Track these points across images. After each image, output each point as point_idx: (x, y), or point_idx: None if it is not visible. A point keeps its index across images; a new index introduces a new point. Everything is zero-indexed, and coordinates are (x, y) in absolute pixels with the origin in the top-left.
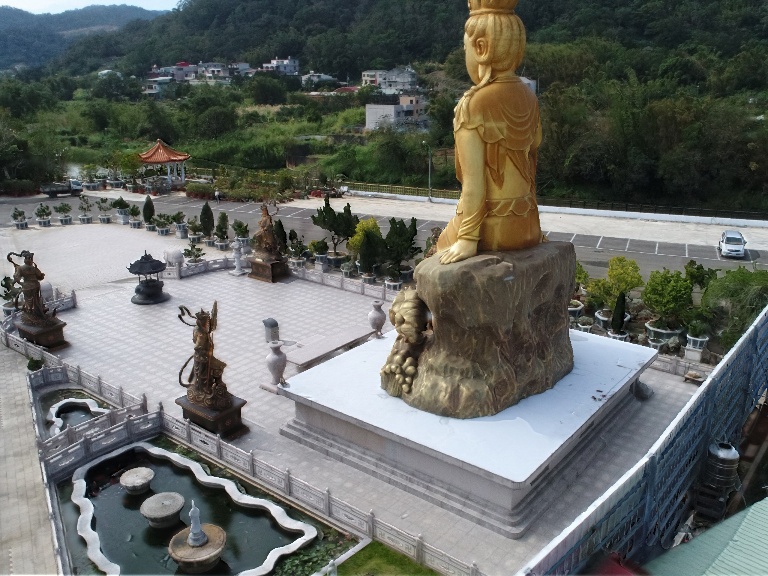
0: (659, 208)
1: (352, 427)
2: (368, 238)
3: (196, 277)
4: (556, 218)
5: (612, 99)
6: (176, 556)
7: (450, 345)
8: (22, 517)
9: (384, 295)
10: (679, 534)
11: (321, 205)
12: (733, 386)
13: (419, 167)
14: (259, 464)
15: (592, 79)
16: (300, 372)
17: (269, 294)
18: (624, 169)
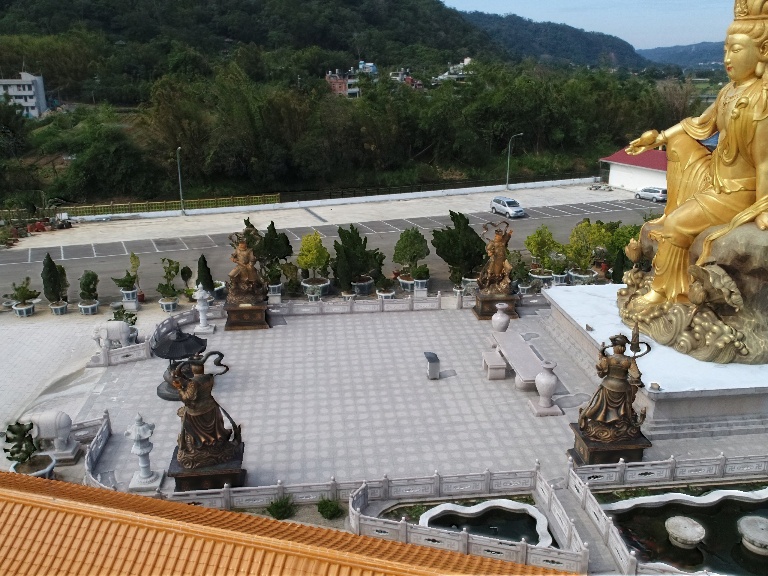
0: (403, 188)
1: (728, 401)
2: (344, 253)
3: None
4: (333, 210)
5: (236, 94)
6: None
7: (763, 303)
8: None
9: (412, 306)
10: None
11: (69, 239)
12: None
13: (26, 183)
14: (734, 461)
15: (206, 74)
16: (530, 390)
17: (300, 339)
18: (262, 161)
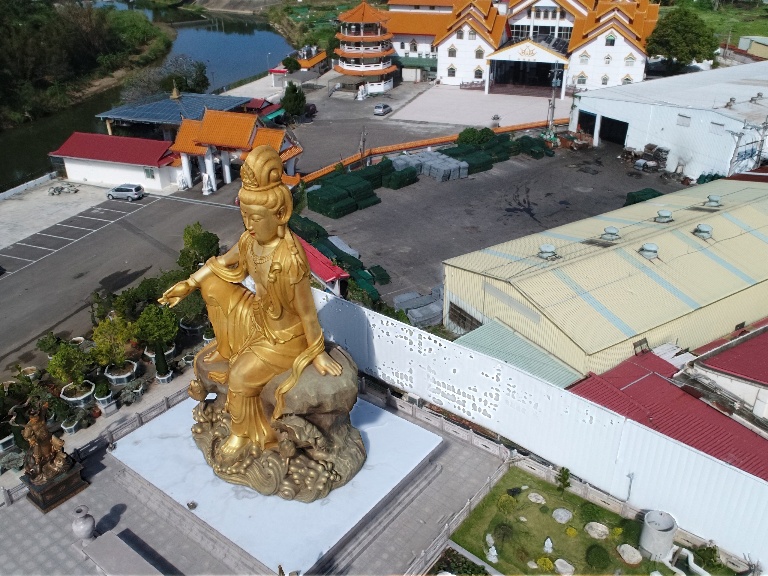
0: None
1: None
2: None
3: None
4: None
5: None
6: None
7: None
8: None
9: None
10: (425, 409)
11: None
12: None
13: None
14: None
15: None
16: None
17: None
18: None
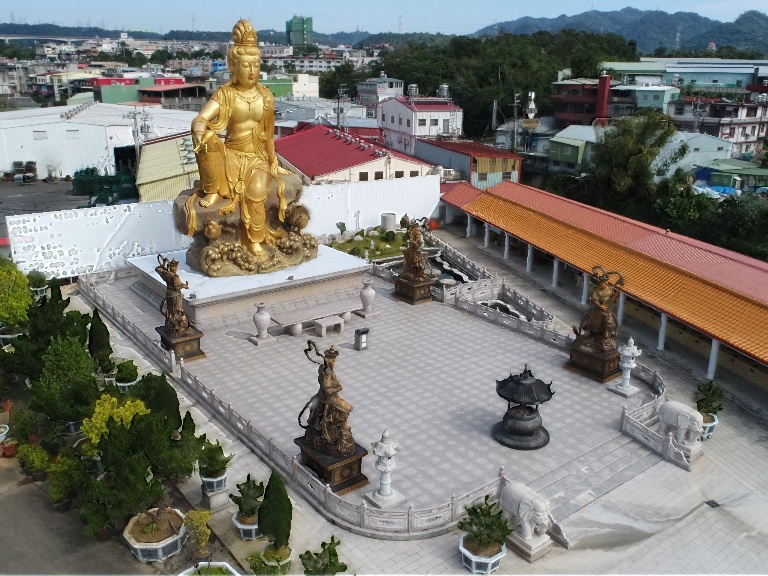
0: None
1: None
2: None
3: None
4: None
5: None
6: None
7: None
8: None
9: None
10: None
11: None
12: (168, 224)
13: None
14: None
15: None
16: None
17: None
18: None
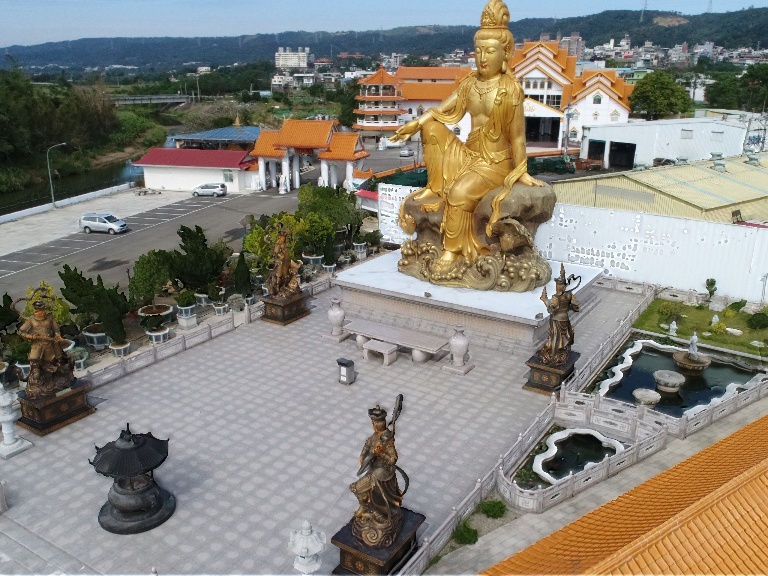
0: None
1: None
2: None
3: (5, 491)
4: None
5: None
6: (710, 361)
7: None
8: (731, 433)
9: None
10: None
11: None
12: None
13: None
14: None
15: None
16: None
17: (158, 406)
18: None
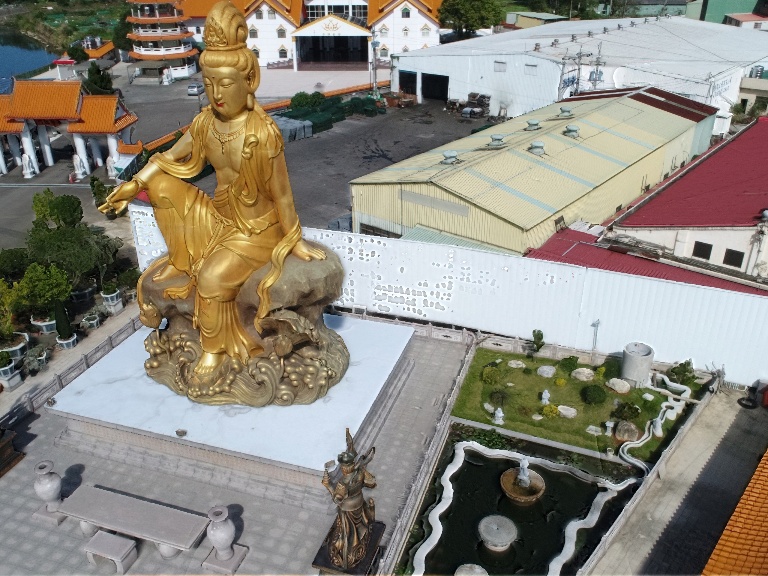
0: None
1: None
2: None
3: None
4: None
5: None
6: None
7: None
8: None
9: None
10: None
11: None
12: None
13: None
14: None
15: None
16: None
17: None
18: None
